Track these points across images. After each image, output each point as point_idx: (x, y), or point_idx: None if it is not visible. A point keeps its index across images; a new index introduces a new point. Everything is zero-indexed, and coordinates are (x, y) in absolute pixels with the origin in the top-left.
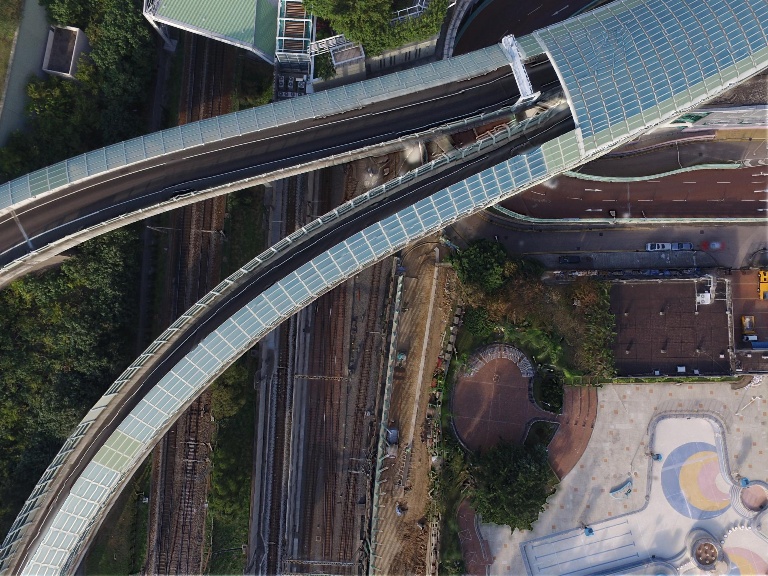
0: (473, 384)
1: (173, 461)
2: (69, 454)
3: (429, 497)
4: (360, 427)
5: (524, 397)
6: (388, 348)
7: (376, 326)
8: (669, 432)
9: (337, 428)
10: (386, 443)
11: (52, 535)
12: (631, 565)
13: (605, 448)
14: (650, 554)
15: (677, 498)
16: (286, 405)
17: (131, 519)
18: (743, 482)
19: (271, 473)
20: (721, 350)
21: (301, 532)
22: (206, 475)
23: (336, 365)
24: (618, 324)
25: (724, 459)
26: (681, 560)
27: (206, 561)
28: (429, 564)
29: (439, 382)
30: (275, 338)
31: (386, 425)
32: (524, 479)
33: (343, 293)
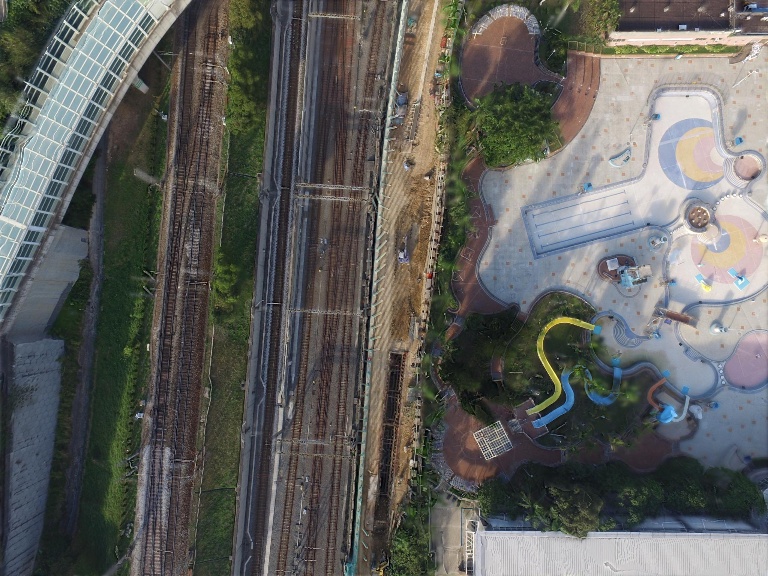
0: (481, 48)
1: (191, 81)
2: (95, 8)
3: (436, 152)
4: (370, 89)
5: (530, 61)
6: (399, 15)
7: None
8: (668, 109)
9: (348, 90)
10: (395, 104)
11: (81, 58)
12: (627, 231)
13: (606, 119)
14: (645, 222)
15: (673, 170)
16: (300, 55)
17: (150, 136)
18: (737, 140)
19: (284, 120)
20: (722, 10)
21: None
22: (223, 97)
23: (348, 31)
24: None
25: (719, 130)
26: (674, 226)
27: (222, 177)
28: (434, 214)
29: (448, 40)
30: None
31: (396, 87)
32: (529, 96)
33: None
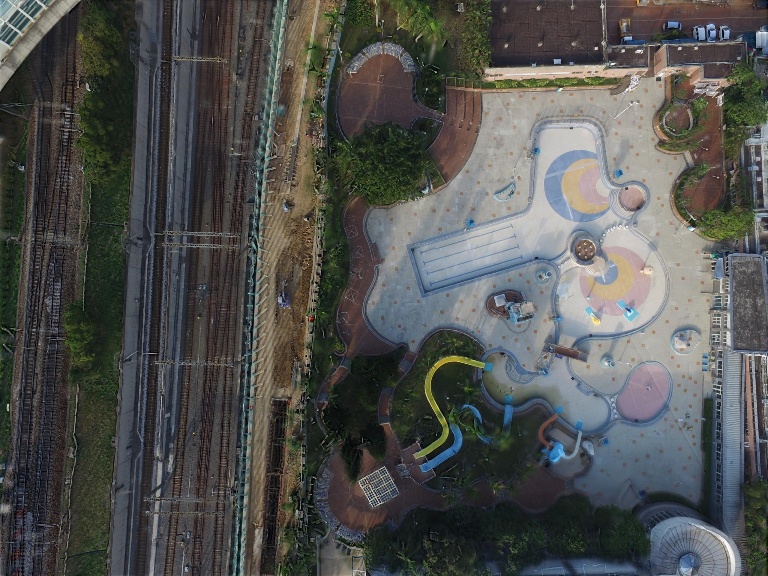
0: (359, 86)
1: (49, 130)
2: None
3: (315, 192)
4: (248, 130)
5: (408, 98)
6: (276, 54)
7: (264, 34)
8: (552, 141)
9: (225, 131)
10: (274, 145)
11: None
12: (515, 266)
13: (490, 153)
14: (533, 256)
15: (559, 202)
16: (170, 99)
17: (8, 188)
18: (617, 172)
19: (156, 165)
20: (595, 43)
21: (190, 230)
22: None
23: (224, 71)
24: (497, 19)
25: (603, 162)
26: (562, 259)
27: (84, 228)
28: (315, 256)
29: (323, 79)
30: (158, 31)
31: (273, 127)
32: (395, 138)
33: (231, 2)
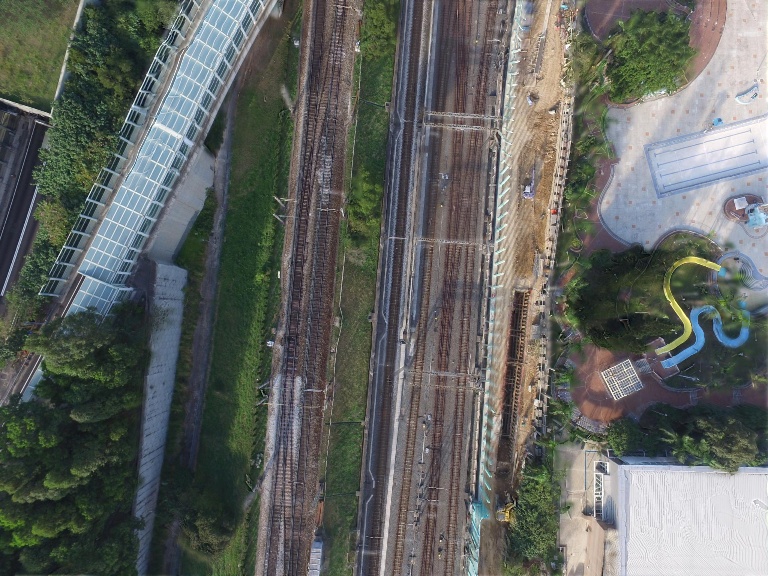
0: None
1: (324, 6)
2: None
3: (561, 86)
4: (492, 24)
5: None
6: None
7: None
8: None
9: (470, 24)
10: (518, 38)
11: None
12: (753, 170)
13: (732, 55)
14: None
15: None
16: None
17: (281, 62)
18: None
19: (408, 52)
20: None
21: (433, 120)
22: (355, 23)
23: None
24: None
25: None
26: None
27: (354, 104)
28: (559, 150)
29: None
30: None
31: (519, 21)
32: (672, 20)
33: None
